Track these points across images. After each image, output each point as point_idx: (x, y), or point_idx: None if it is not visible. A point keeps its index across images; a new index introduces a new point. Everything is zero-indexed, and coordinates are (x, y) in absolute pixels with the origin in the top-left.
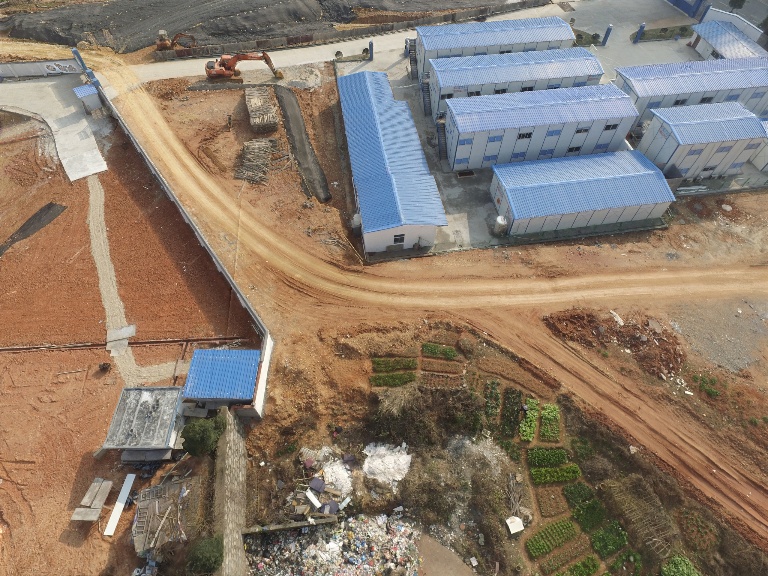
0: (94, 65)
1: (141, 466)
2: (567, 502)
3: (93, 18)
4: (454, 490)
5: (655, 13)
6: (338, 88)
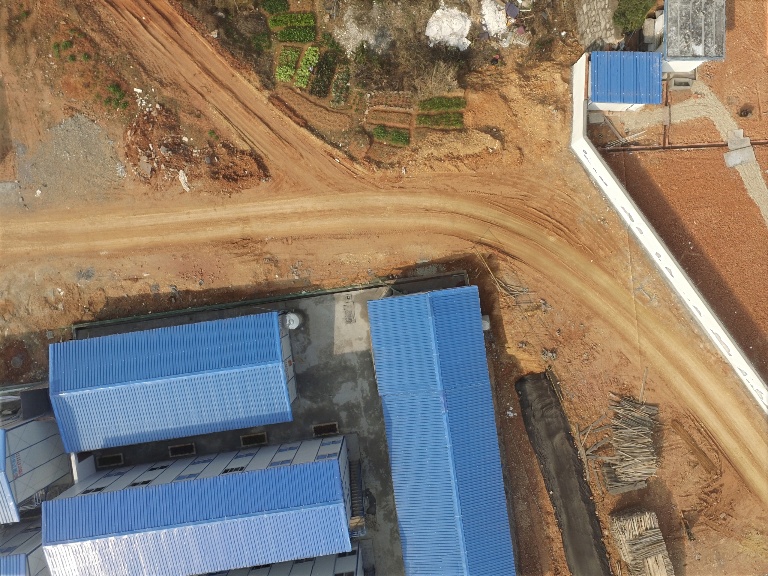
0: None
1: None
2: None
3: None
4: None
5: None
6: None
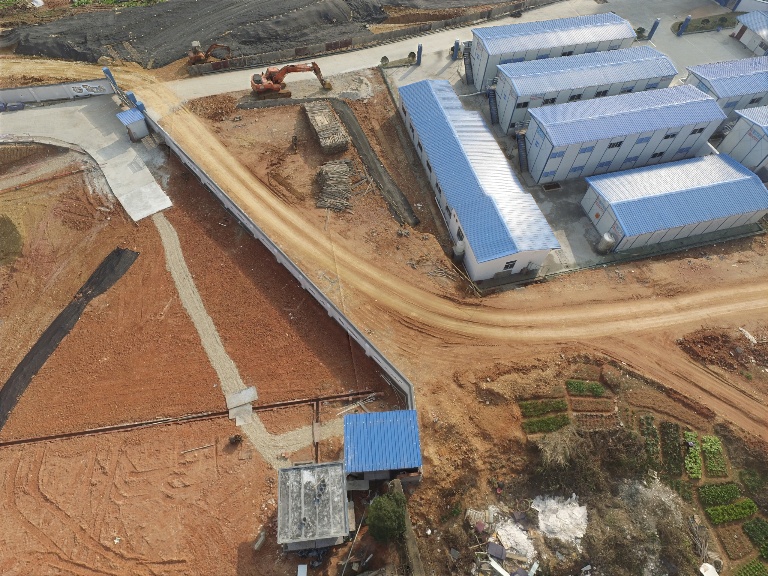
0: (123, 84)
1: (307, 552)
2: (751, 541)
3: (108, 29)
4: (642, 542)
5: (687, 3)
6: (402, 99)
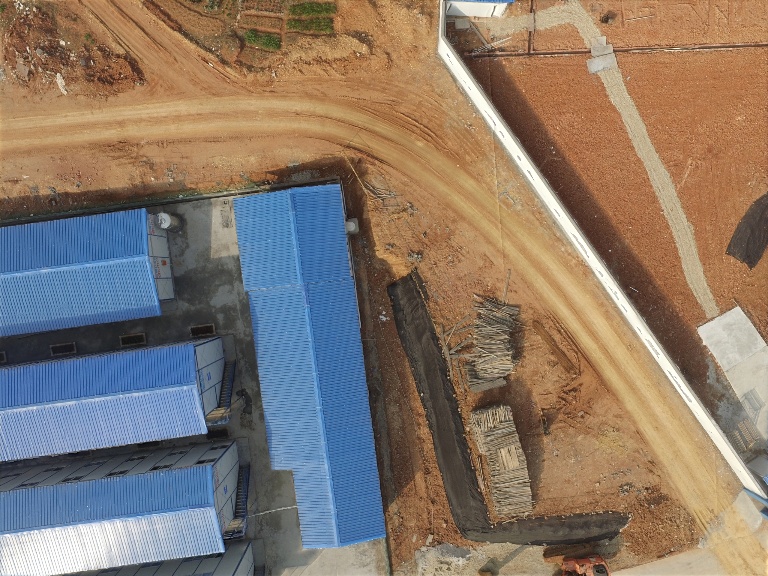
0: None
1: None
2: None
3: None
4: None
5: None
6: None
